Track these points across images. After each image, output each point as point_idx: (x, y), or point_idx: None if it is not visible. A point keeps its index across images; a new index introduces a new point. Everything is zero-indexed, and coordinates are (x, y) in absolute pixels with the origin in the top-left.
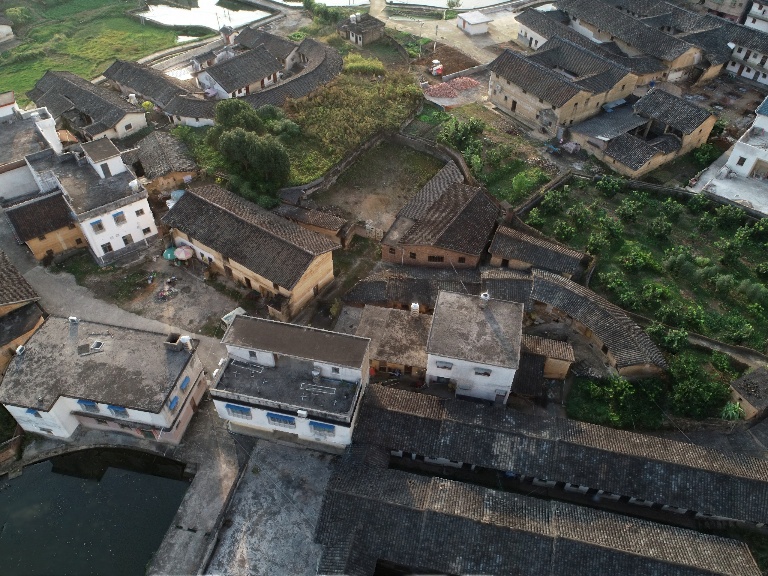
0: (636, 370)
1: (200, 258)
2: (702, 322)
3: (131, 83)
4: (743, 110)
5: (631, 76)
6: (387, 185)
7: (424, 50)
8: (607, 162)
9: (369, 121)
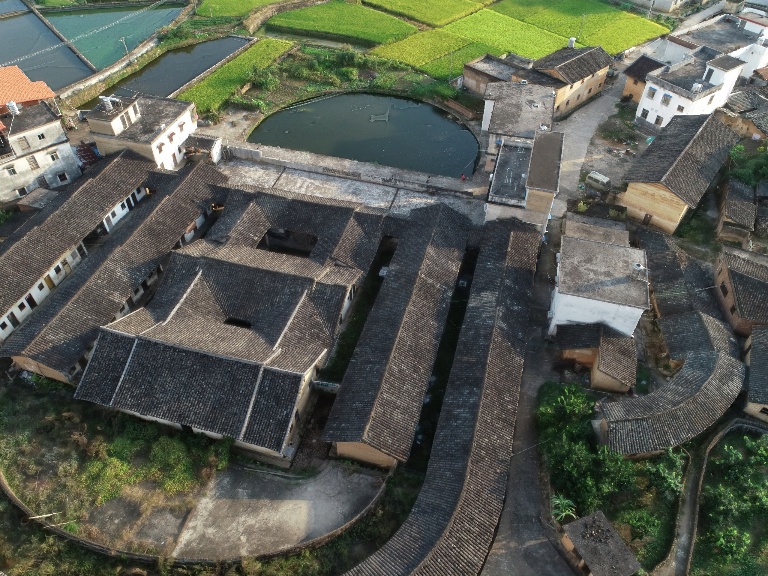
0: None
1: None
2: None
3: None
4: None
5: None
6: None
7: None
8: None
9: None
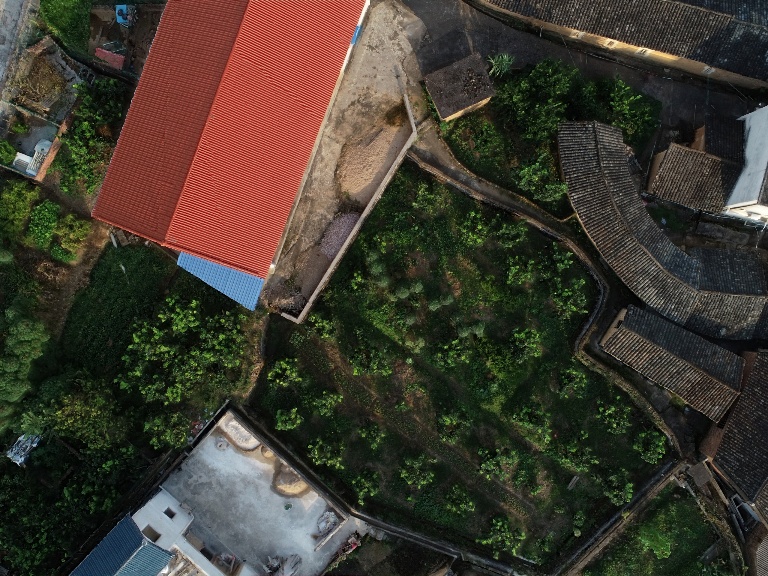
0: None
1: None
2: None
3: None
4: None
5: None
6: None
7: None
8: None
9: None
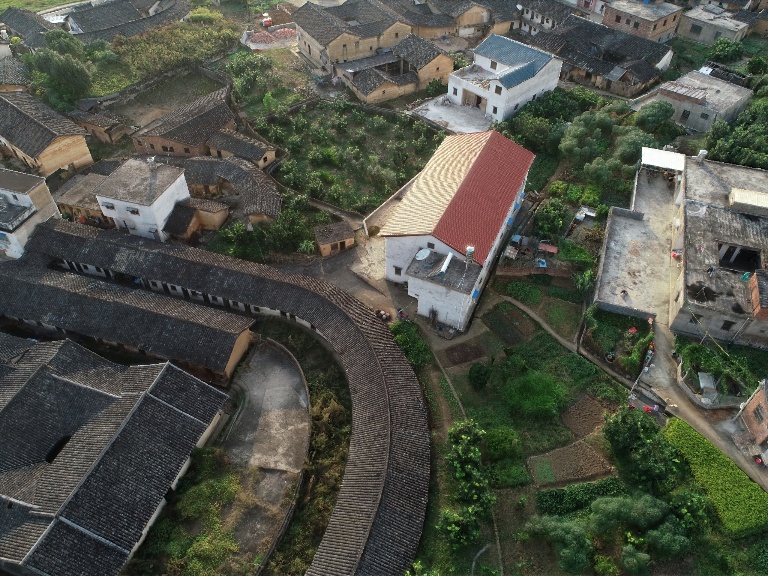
0: (260, 221)
1: (1, 145)
2: (335, 195)
3: (13, 24)
4: None
5: (402, 26)
6: (175, 103)
7: (272, 8)
8: (355, 91)
9: (177, 55)
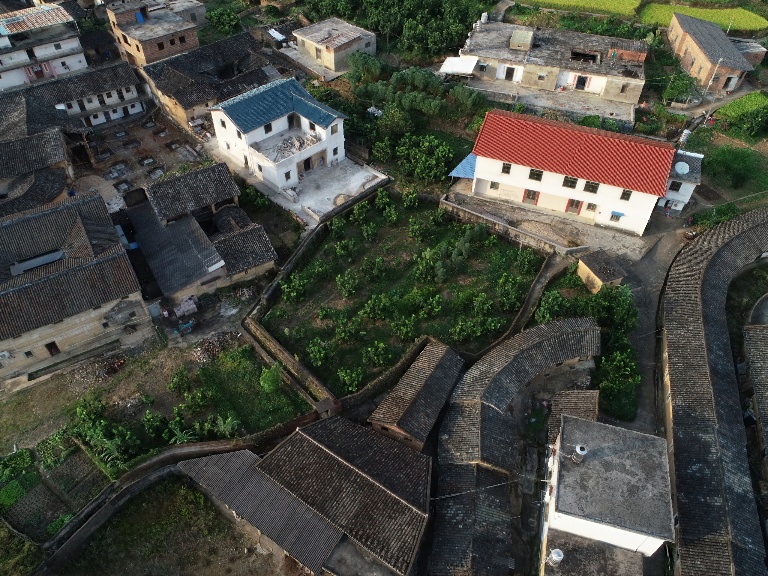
0: None
1: None
2: None
3: None
4: (164, 147)
5: None
6: None
7: None
8: (238, 279)
9: None
